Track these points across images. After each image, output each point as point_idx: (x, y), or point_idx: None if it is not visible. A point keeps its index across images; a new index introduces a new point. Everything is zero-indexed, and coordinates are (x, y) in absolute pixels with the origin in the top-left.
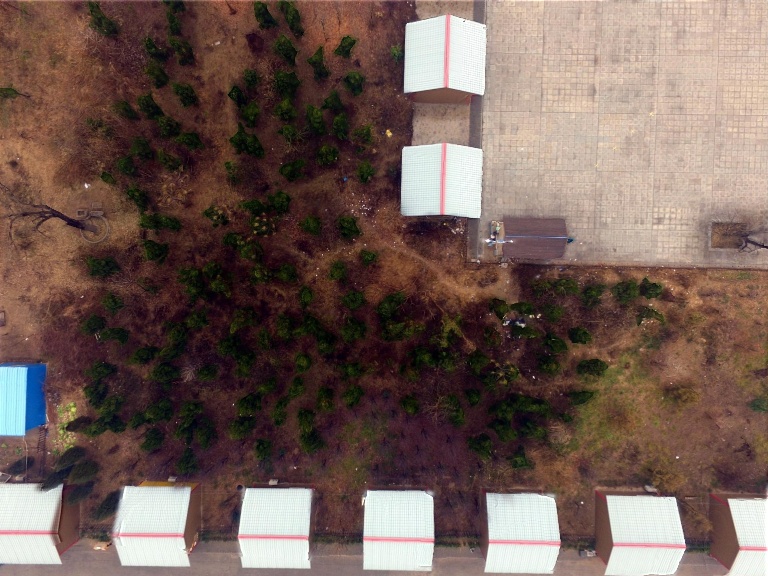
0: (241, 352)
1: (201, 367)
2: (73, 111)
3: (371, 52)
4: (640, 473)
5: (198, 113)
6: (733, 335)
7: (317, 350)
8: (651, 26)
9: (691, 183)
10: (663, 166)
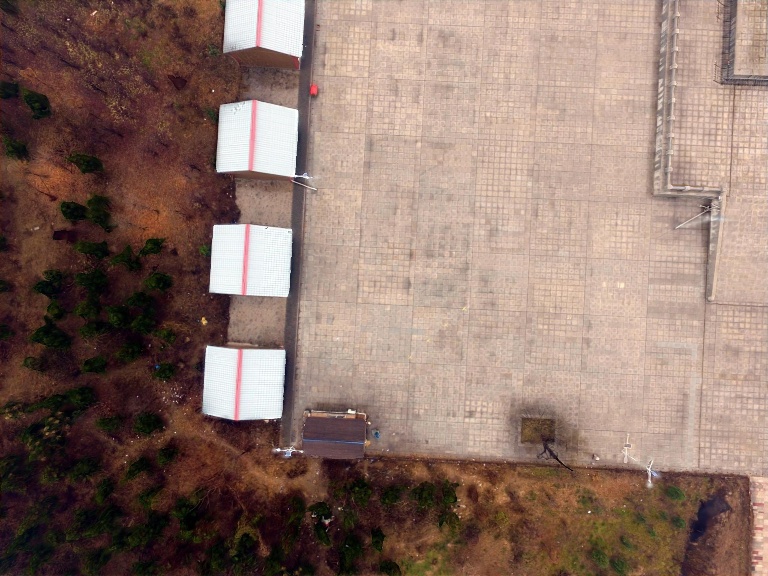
0: (36, 547)
1: None
2: None
3: (189, 241)
4: None
5: (13, 297)
6: (540, 533)
7: None
8: (465, 224)
9: (502, 378)
10: (475, 360)
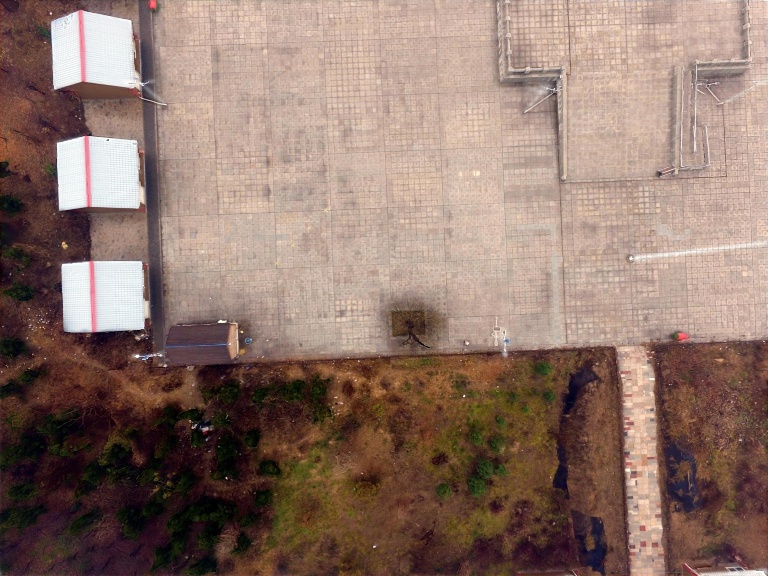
0: None
1: None
2: None
3: (41, 167)
4: (339, 566)
5: None
6: (418, 421)
7: (1, 469)
8: (319, 126)
9: (369, 275)
10: (341, 260)
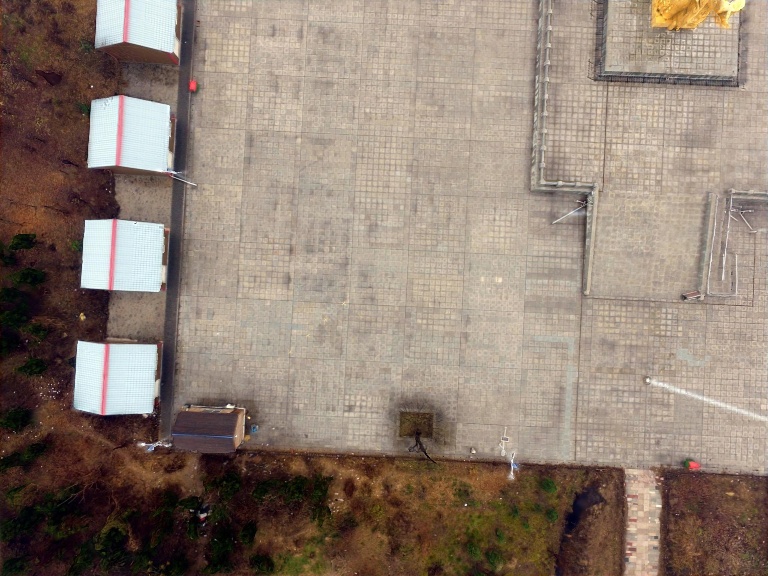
0: None
1: None
2: None
3: (68, 237)
4: None
5: None
6: (417, 526)
7: None
8: (345, 219)
9: (381, 372)
10: (355, 354)
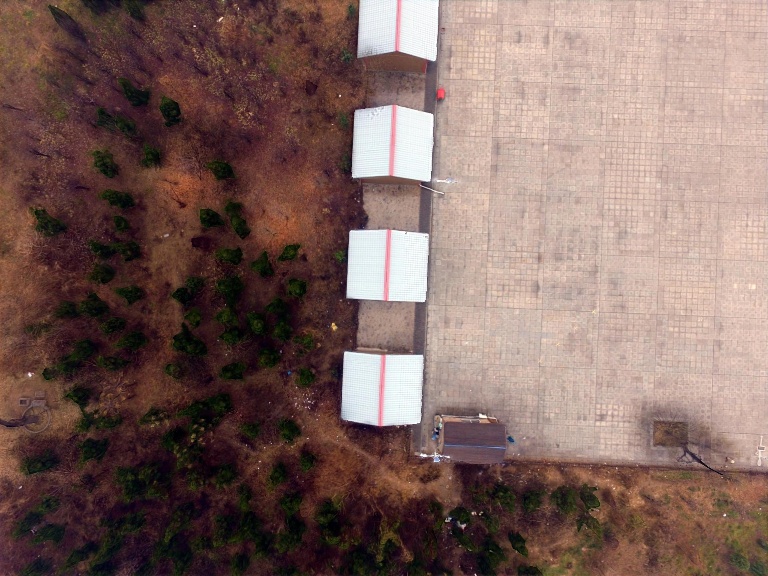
0: (177, 553)
1: (135, 572)
2: (20, 300)
3: (318, 247)
4: None
5: (145, 304)
6: (675, 536)
7: None
8: (593, 226)
9: (633, 381)
10: (605, 363)
